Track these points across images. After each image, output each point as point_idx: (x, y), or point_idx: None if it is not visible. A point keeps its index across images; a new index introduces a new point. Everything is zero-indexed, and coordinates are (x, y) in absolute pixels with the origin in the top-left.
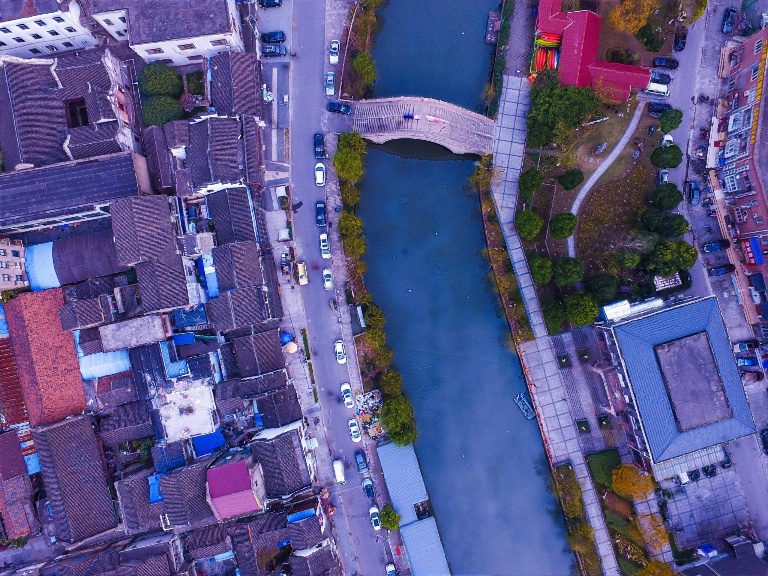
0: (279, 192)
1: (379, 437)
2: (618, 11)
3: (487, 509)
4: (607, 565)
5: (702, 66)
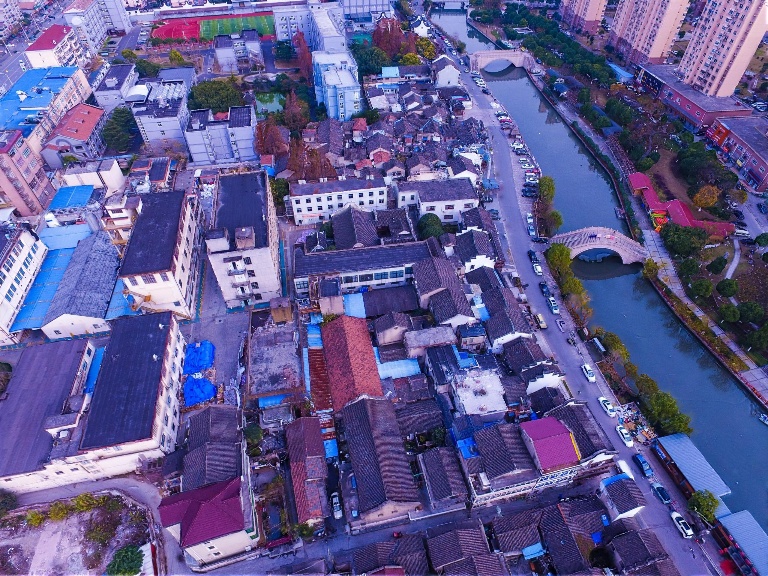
0: (514, 274)
1: (650, 443)
2: (698, 195)
3: None
4: None
5: (761, 226)
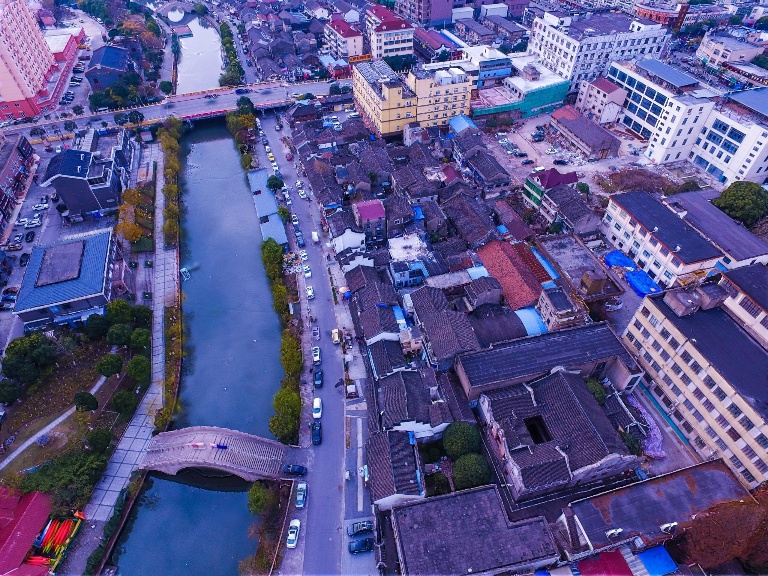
0: (352, 387)
1: None
2: None
3: (228, 233)
4: (161, 210)
5: None
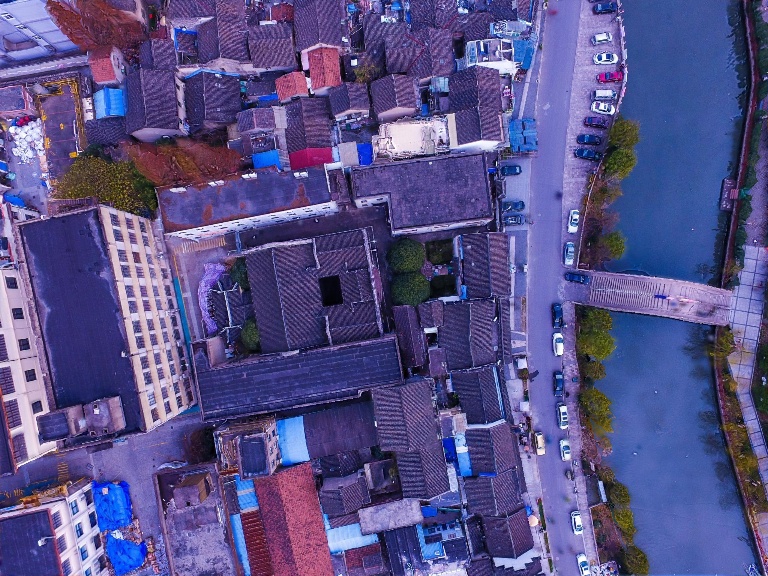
0: (522, 365)
1: None
2: None
3: None
4: None
5: None
